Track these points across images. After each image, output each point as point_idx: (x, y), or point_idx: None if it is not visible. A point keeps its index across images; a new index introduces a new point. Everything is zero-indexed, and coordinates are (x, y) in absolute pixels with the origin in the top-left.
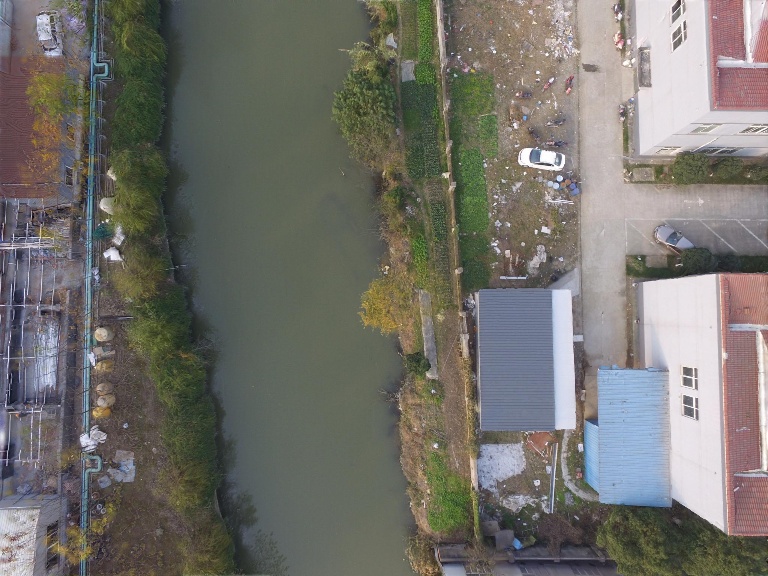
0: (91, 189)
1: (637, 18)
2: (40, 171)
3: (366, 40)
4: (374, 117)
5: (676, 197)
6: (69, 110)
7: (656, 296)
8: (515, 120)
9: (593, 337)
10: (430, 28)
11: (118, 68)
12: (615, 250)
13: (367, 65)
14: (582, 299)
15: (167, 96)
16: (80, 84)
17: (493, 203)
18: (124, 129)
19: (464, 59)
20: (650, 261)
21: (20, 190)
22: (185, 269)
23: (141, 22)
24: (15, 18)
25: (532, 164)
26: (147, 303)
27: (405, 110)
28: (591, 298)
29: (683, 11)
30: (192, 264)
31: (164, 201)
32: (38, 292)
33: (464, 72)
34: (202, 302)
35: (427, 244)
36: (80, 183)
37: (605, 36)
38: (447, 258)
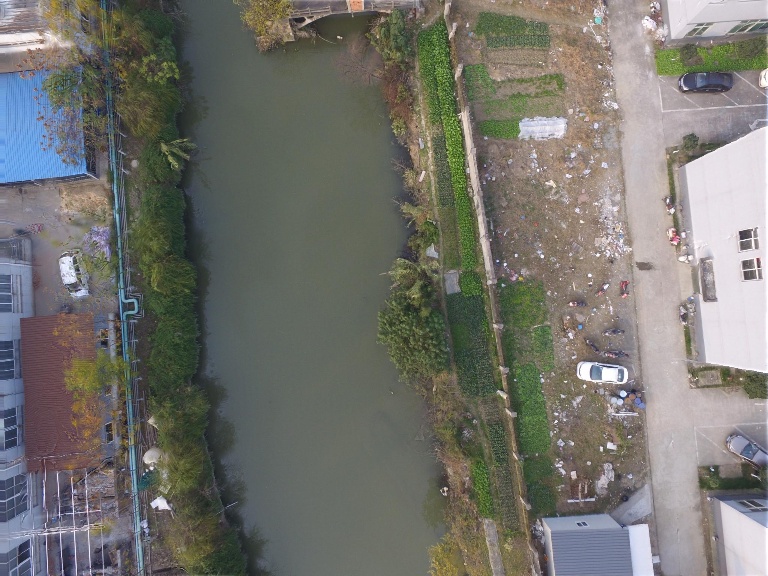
0: (132, 437)
1: (692, 214)
2: (81, 440)
3: (403, 245)
4: (427, 357)
5: (746, 400)
6: (107, 382)
7: (739, 527)
8: (570, 329)
9: (670, 557)
10: (472, 234)
11: (148, 306)
12: (686, 462)
13: (412, 293)
14: (655, 517)
15: (200, 321)
16: (110, 325)
17: (554, 421)
18: (161, 374)
19: (511, 267)
20: (724, 471)
21: (61, 462)
22: (235, 506)
23: (170, 260)
24: (34, 254)
25: (593, 381)
26: (203, 562)
27: (452, 325)
28: (664, 515)
29: (755, 246)
30: (242, 500)
31: (207, 436)
32: (86, 549)
33: (512, 281)
34: (254, 533)
35: (488, 469)
36: (120, 434)
37: (658, 230)
38: (510, 482)
